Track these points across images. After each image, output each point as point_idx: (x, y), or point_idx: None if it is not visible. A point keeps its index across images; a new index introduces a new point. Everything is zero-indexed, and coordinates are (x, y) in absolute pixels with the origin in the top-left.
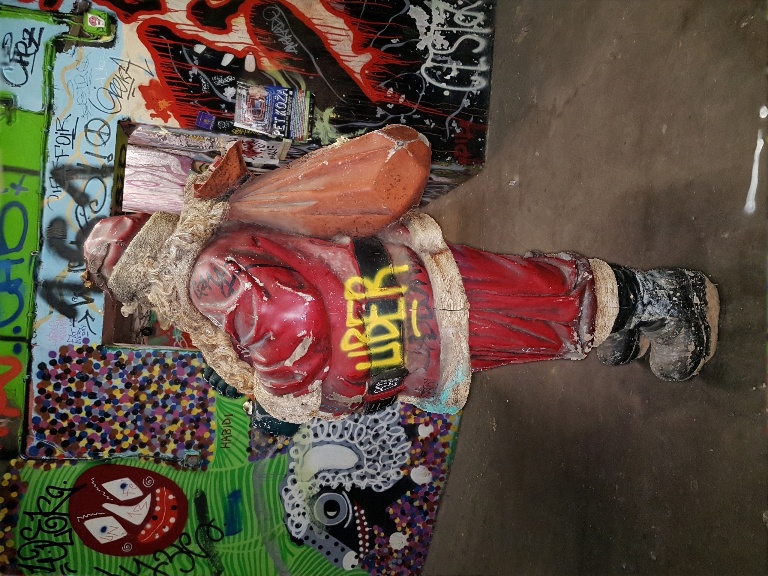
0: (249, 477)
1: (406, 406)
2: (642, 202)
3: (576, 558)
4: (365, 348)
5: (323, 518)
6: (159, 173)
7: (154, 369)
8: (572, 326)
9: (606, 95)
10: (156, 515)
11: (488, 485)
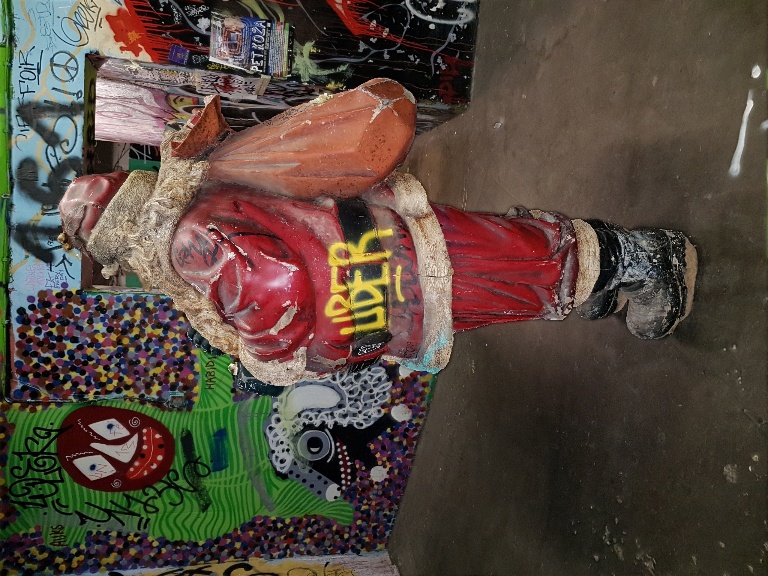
0: (234, 416)
1: None
2: (628, 156)
3: (547, 497)
4: (349, 313)
5: (307, 454)
6: (131, 105)
7: (135, 313)
8: (553, 289)
9: (597, 40)
10: (144, 453)
11: (466, 424)
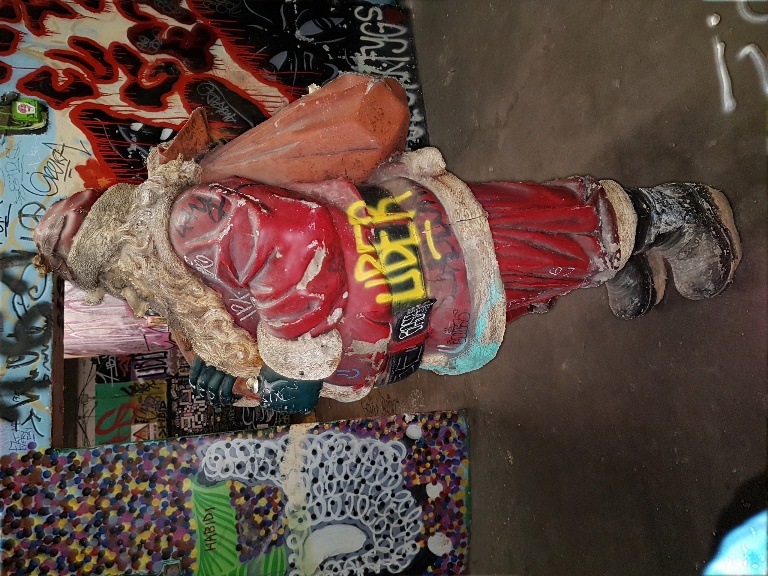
0: None
1: (408, 466)
2: (614, 158)
3: (651, 554)
4: (382, 276)
5: None
6: None
7: (116, 467)
8: None
9: (549, 84)
10: None
11: (520, 526)
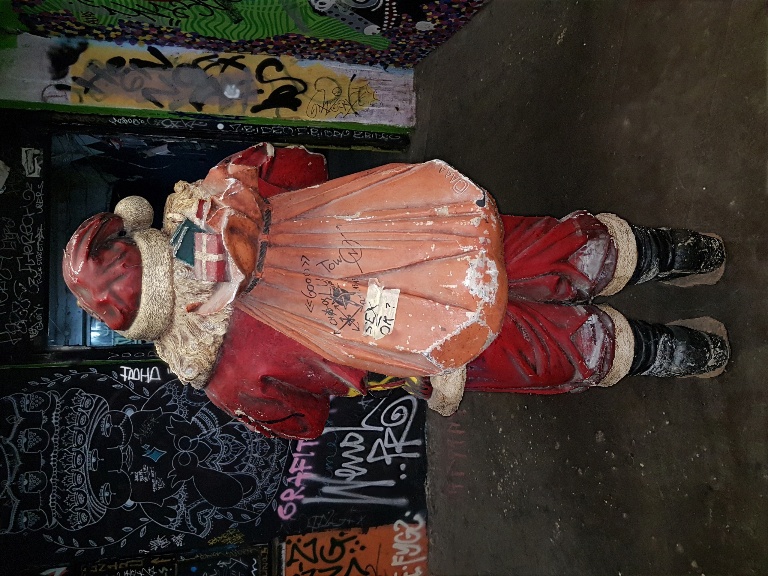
0: None
1: None
2: None
3: None
4: None
5: (350, 2)
6: None
7: None
8: None
9: None
10: None
11: (520, 83)
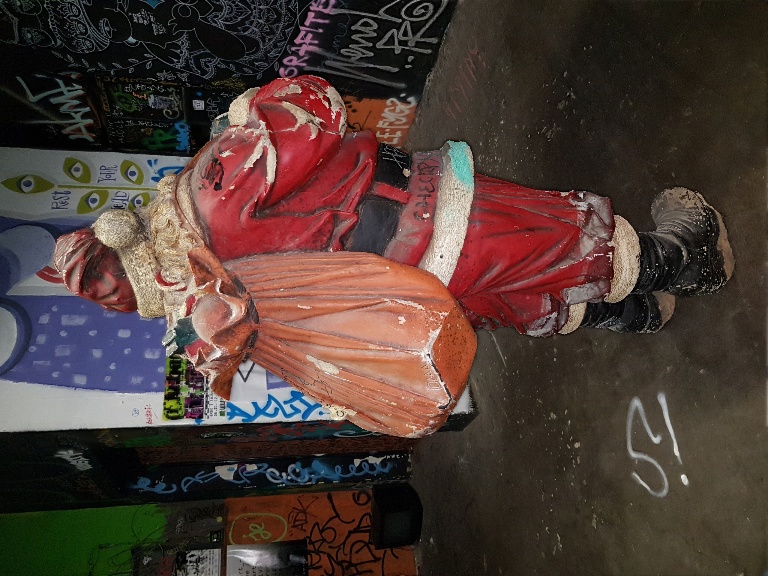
0: None
1: None
2: None
3: (619, 4)
4: None
5: None
6: None
7: None
8: None
9: None
10: None
11: None
